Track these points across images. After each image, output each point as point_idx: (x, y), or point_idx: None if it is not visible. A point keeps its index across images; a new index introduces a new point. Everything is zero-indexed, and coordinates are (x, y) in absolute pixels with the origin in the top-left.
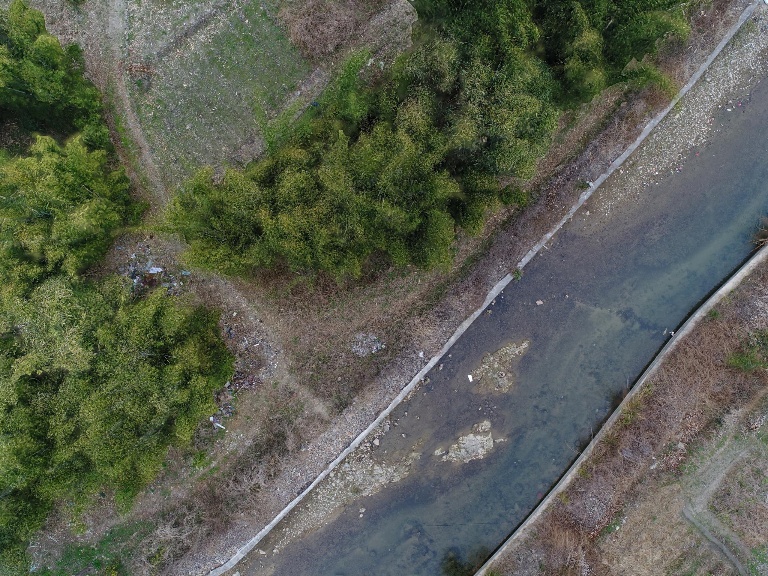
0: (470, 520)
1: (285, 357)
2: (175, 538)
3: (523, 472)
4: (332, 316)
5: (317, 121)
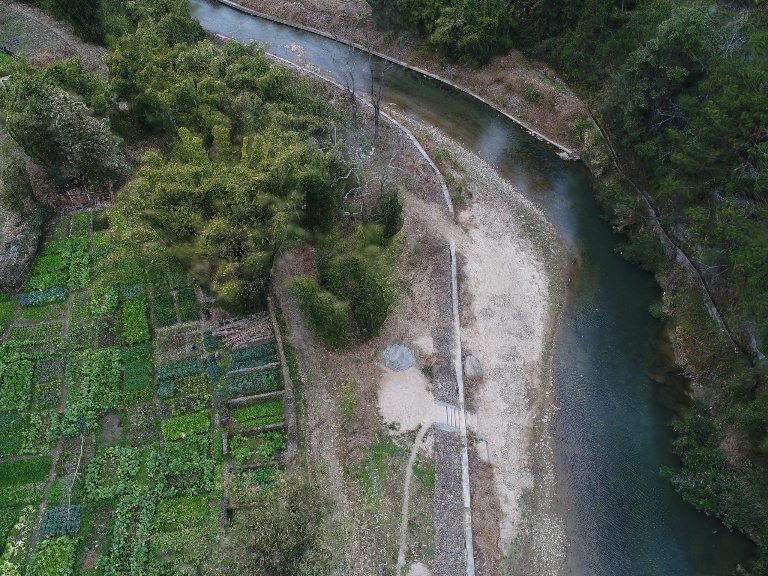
0: (332, 50)
1: None
2: None
3: (310, 41)
4: None
5: (126, 49)
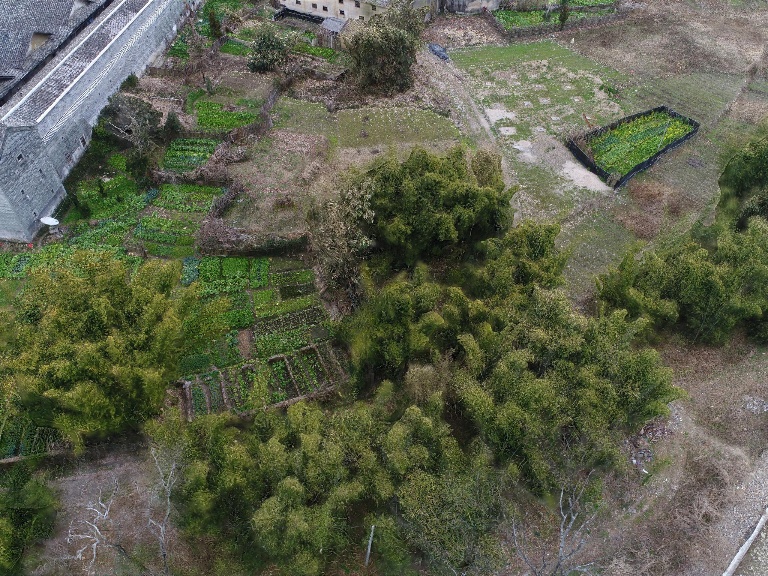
0: None
1: (687, 413)
2: (632, 575)
3: None
4: (717, 383)
5: None
